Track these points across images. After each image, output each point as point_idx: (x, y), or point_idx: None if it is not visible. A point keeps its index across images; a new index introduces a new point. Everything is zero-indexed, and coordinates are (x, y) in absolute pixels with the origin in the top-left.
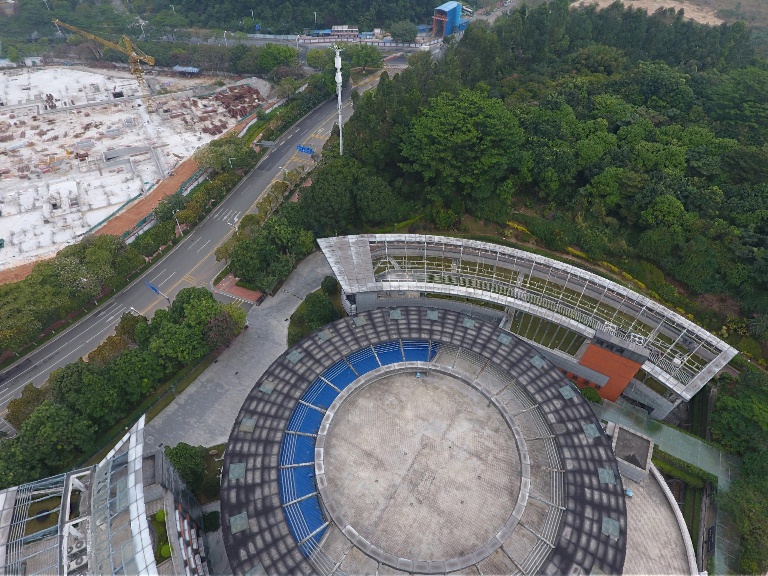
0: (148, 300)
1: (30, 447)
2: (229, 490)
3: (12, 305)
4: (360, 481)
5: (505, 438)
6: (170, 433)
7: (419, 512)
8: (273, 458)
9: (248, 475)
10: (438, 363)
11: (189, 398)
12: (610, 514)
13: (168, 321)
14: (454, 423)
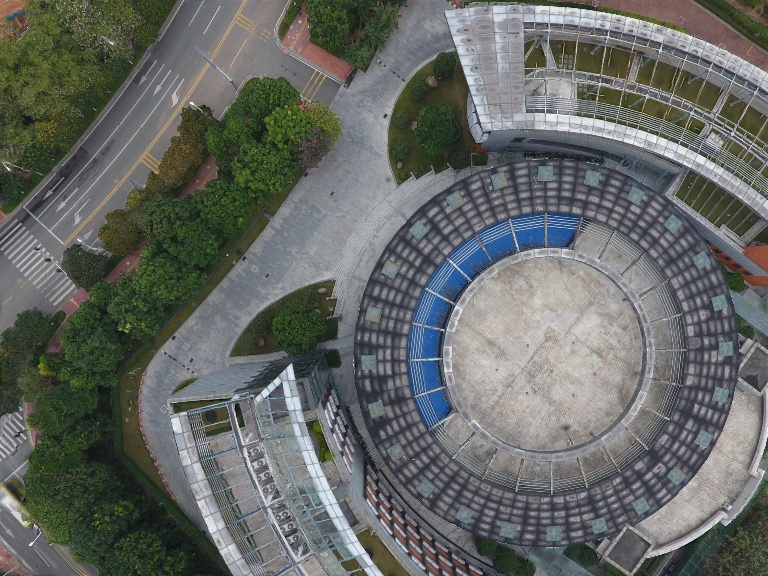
0: (197, 59)
1: (149, 299)
2: (363, 380)
3: (34, 88)
4: (481, 369)
5: (631, 337)
6: (273, 263)
7: (533, 401)
8: (402, 351)
9: (379, 367)
10: (581, 240)
11: (284, 222)
12: (708, 428)
13: (246, 135)
14: (583, 317)
